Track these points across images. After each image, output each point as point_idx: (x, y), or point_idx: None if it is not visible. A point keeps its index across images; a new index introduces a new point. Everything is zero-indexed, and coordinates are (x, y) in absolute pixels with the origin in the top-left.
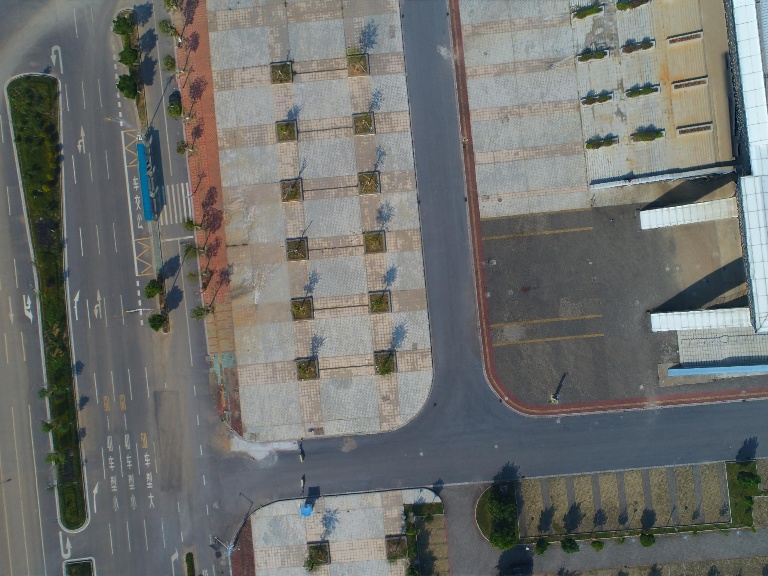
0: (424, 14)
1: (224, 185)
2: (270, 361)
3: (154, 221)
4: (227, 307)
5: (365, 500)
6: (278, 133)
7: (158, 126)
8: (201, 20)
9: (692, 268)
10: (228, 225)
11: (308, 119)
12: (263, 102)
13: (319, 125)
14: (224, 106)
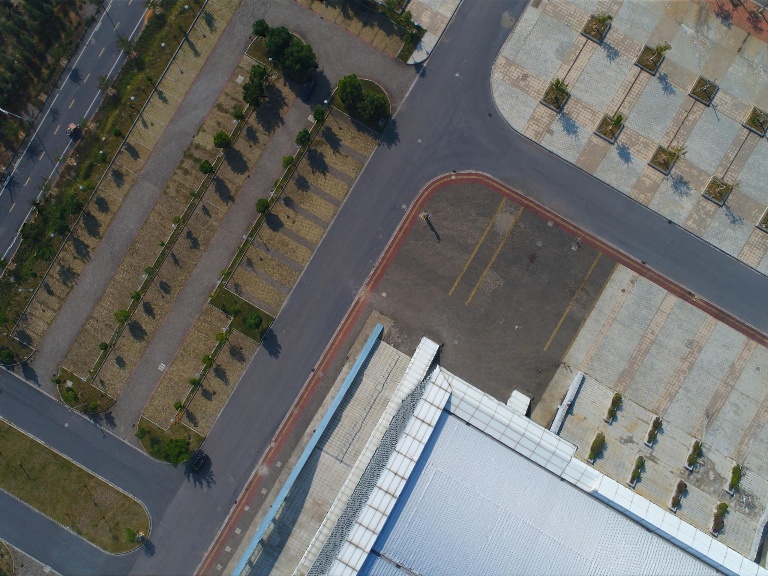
0: None
1: None
2: (624, 3)
3: None
4: None
5: (453, 2)
6: None
7: None
8: None
9: None
10: (767, 47)
11: None
12: None
13: None
14: None
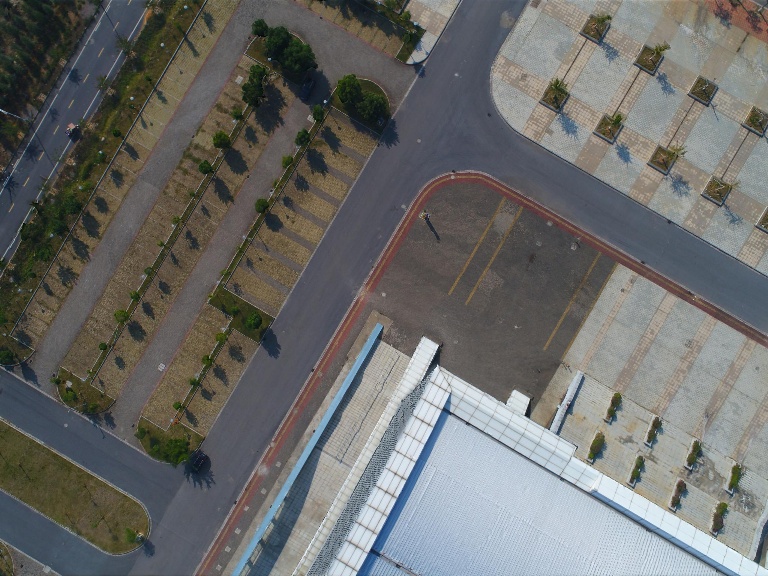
0: None
1: None
2: (624, 3)
3: None
4: None
5: (452, 1)
6: None
7: None
8: None
9: None
10: (766, 47)
11: None
12: None
13: None
14: None
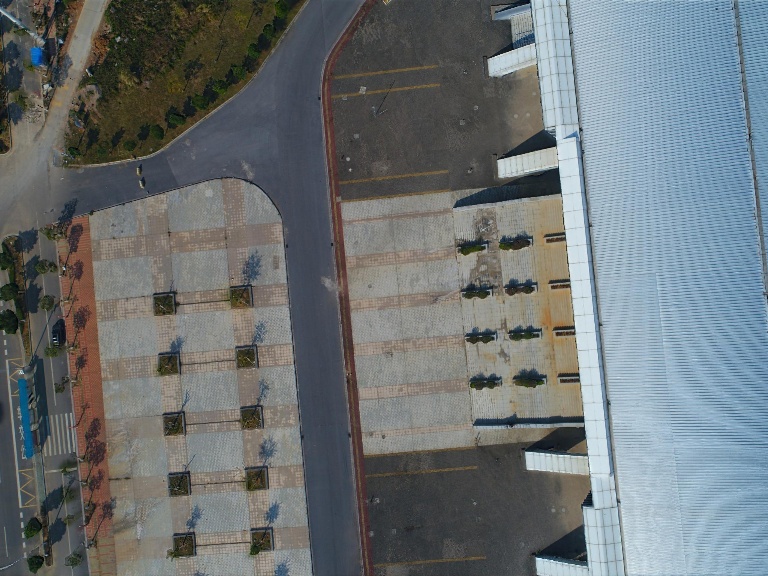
0: (308, 244)
1: (107, 417)
2: None
3: (37, 453)
4: (110, 541)
5: None
6: (160, 366)
7: (42, 355)
8: (85, 248)
9: (578, 510)
10: (111, 458)
11: (191, 351)
12: (146, 333)
13: (202, 358)
14: (107, 337)
